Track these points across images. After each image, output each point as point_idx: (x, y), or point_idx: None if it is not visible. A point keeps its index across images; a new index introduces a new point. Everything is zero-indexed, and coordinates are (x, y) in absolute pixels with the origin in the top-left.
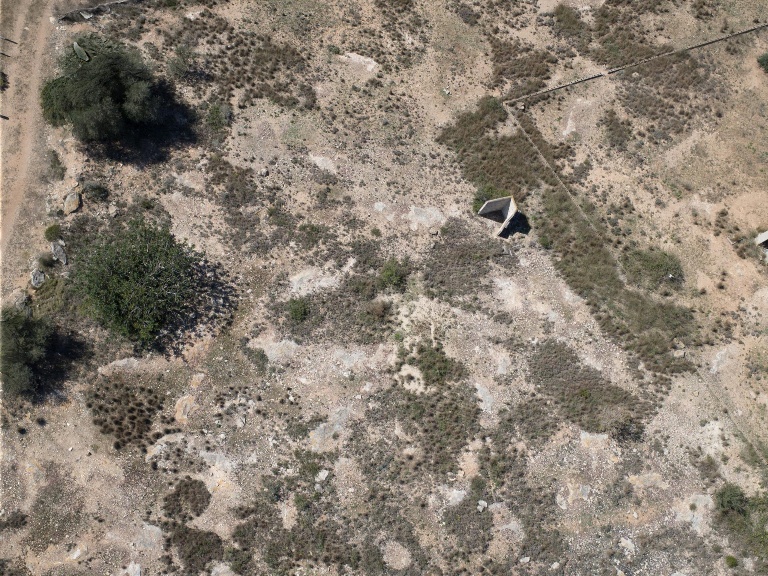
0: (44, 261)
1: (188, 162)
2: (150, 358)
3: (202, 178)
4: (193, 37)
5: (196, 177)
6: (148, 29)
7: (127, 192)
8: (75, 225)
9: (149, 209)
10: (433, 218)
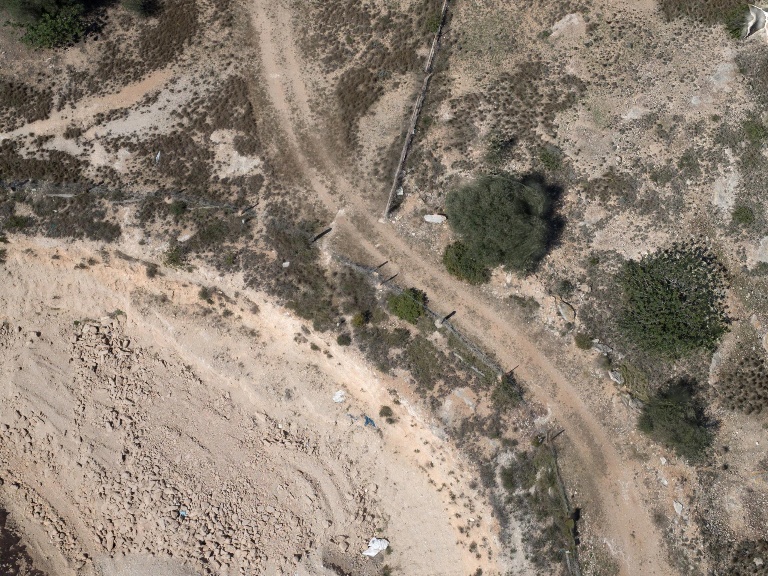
0: (608, 362)
1: (577, 207)
2: (721, 342)
3: (596, 207)
4: (473, 127)
5: (593, 210)
6: (440, 155)
7: (574, 268)
8: (585, 322)
9: (598, 262)
10: (729, 71)
